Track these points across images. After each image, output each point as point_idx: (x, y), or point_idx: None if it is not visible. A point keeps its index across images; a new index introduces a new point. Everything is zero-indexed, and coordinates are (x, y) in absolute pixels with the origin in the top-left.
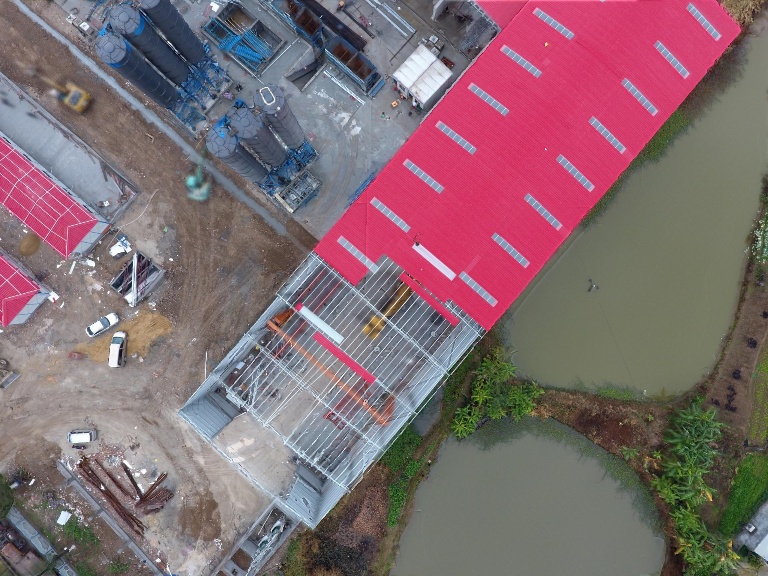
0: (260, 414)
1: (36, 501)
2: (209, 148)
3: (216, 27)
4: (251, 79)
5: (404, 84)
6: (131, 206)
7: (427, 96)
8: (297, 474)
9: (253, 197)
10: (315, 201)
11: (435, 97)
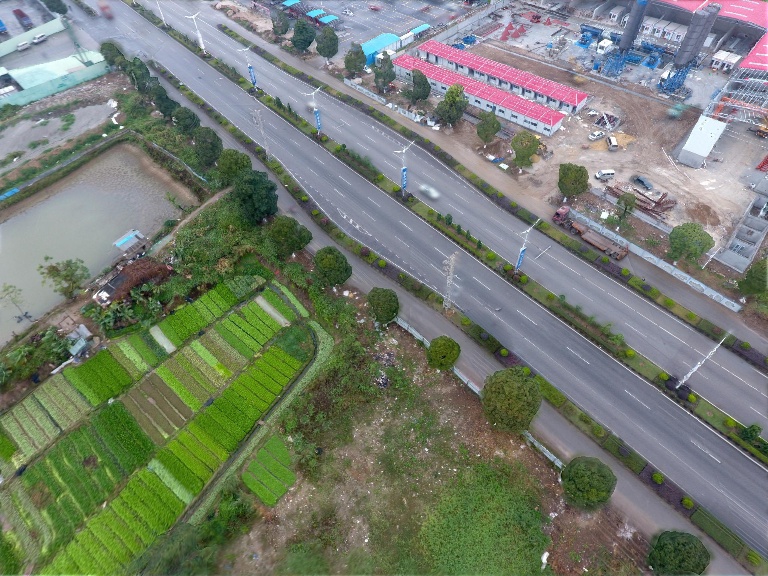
0: (713, 169)
1: (581, 209)
2: (699, 13)
3: (612, 54)
4: (635, 67)
5: (720, 59)
6: (592, 101)
7: (734, 61)
8: (765, 178)
9: (656, 98)
10: (692, 98)
11: (737, 64)
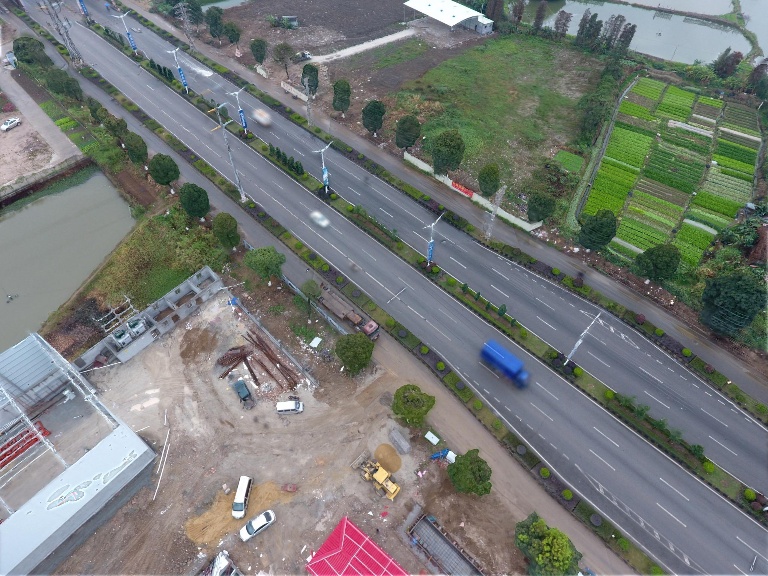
0: None
1: None
2: None
3: None
4: None
5: None
6: None
7: None
8: (83, 379)
9: None
10: None
11: None
